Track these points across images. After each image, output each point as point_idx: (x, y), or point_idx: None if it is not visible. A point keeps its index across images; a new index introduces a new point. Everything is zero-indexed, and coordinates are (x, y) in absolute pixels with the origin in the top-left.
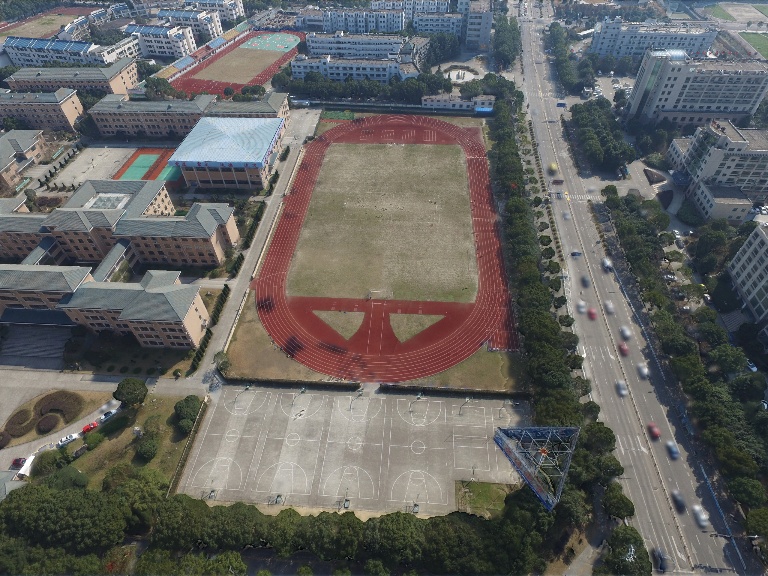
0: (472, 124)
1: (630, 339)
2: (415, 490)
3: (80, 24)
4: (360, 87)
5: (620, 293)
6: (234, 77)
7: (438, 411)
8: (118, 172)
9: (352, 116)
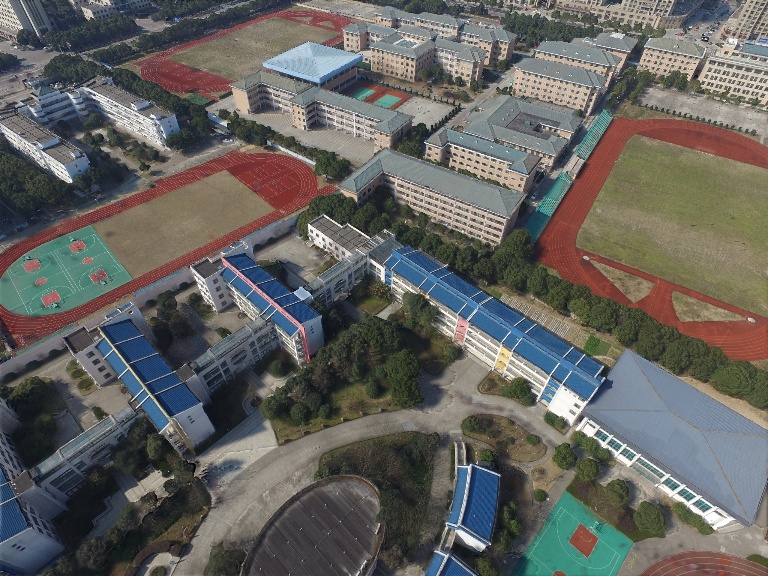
0: (130, 66)
1: (244, 3)
2: (341, 2)
3: (432, 567)
4: (159, 86)
5: (225, 8)
6: (224, 188)
7: (320, 7)
8: (401, 103)
9: (190, 96)
